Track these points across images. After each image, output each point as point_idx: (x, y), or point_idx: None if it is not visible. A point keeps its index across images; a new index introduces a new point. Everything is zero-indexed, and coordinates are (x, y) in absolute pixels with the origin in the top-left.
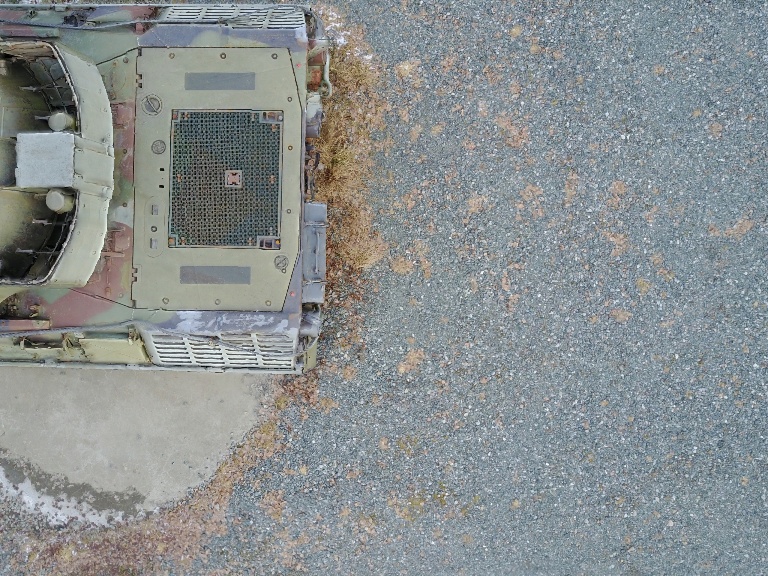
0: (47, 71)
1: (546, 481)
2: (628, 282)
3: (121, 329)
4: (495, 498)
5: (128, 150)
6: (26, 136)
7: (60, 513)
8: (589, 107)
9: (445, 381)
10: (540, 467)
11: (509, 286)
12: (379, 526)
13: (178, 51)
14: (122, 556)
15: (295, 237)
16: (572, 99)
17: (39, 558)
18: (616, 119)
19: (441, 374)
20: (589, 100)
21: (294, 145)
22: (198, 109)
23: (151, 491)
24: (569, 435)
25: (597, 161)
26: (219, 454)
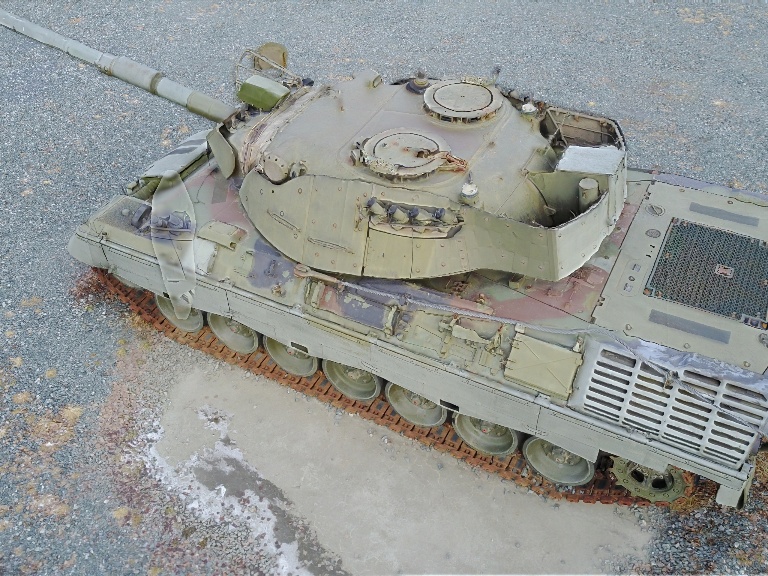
0: None
1: None
2: None
3: (566, 340)
4: None
5: (622, 228)
6: None
7: None
8: None
9: None
10: None
11: None
12: None
13: (689, 189)
14: None
15: None
16: None
17: None
18: None
19: None
20: None
21: None
22: (699, 223)
23: None
24: None
25: None
26: None
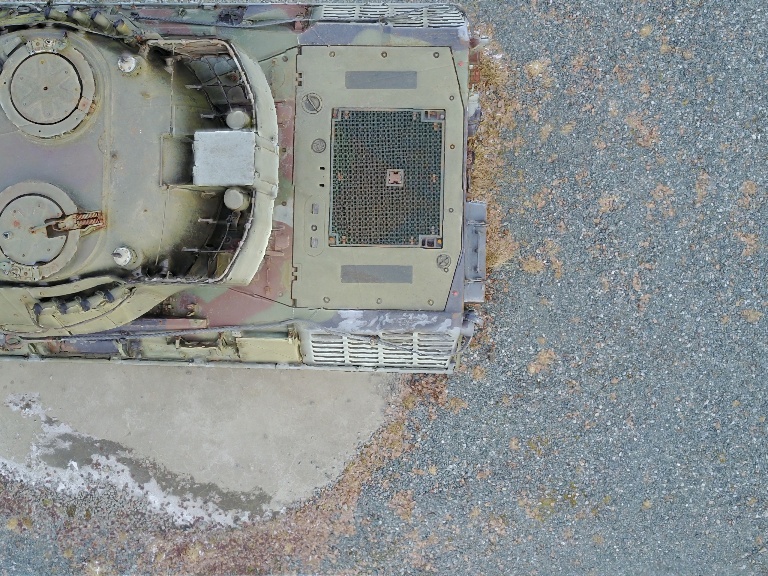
0: (212, 69)
1: (677, 481)
2: (759, 282)
3: (279, 328)
4: (626, 498)
5: (287, 149)
6: (205, 134)
7: (186, 513)
8: (720, 107)
9: (576, 381)
10: (671, 467)
11: (640, 286)
12: (509, 526)
13: (339, 50)
14: (249, 556)
15: (457, 236)
16: (703, 99)
17: (166, 558)
18: (747, 119)
19: (572, 374)
20: (720, 100)
21: (456, 144)
22: (359, 108)
23: (277, 491)
24: (700, 435)
25: (728, 161)
26: (346, 454)
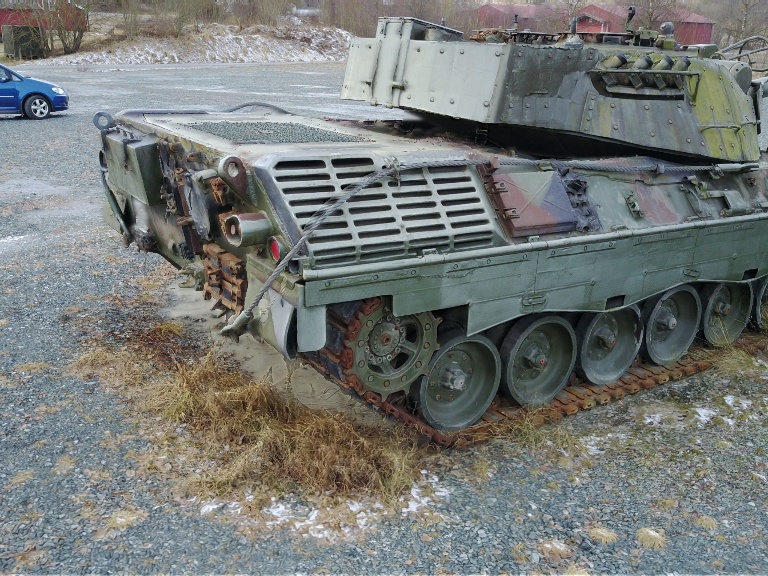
0: None
1: None
2: None
3: None
4: None
5: None
6: None
7: None
8: None
9: None
10: None
11: None
12: None
13: None
14: None
15: None
16: None
17: None
18: None
19: None
20: None
21: None
22: None
23: None
24: None
25: None
26: None
